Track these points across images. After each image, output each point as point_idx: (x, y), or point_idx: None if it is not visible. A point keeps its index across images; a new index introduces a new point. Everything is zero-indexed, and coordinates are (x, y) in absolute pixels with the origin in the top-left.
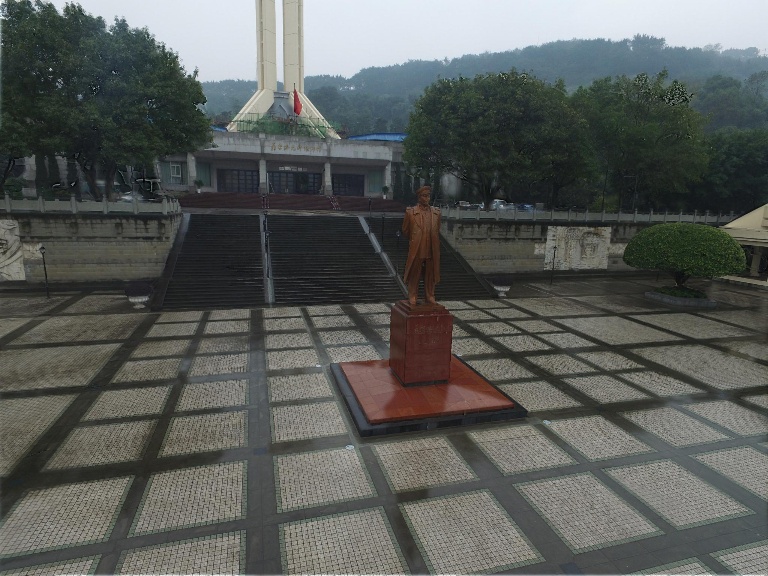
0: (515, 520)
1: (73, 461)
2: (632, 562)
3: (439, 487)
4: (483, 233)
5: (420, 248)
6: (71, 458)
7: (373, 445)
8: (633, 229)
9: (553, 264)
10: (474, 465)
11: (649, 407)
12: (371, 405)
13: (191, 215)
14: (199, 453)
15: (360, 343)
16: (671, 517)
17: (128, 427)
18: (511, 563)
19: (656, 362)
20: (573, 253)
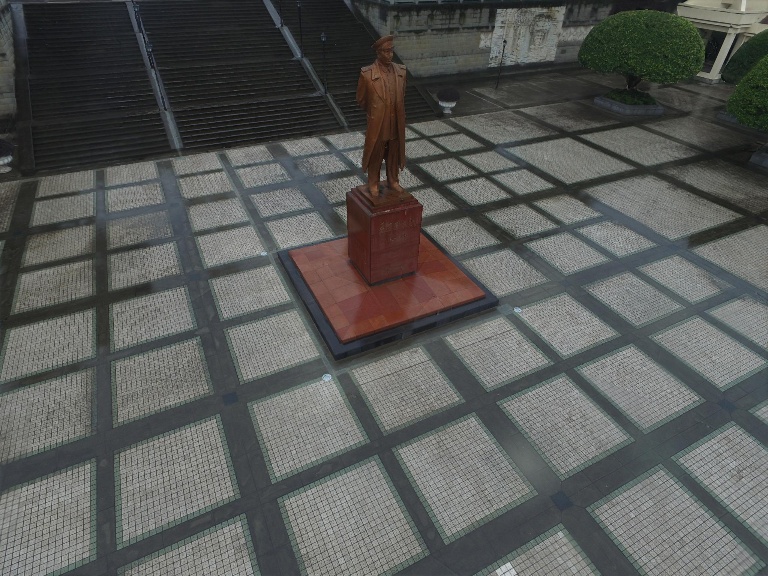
0: (505, 449)
1: (11, 450)
2: (610, 480)
3: (428, 419)
4: (422, 23)
5: (383, 127)
6: (7, 446)
7: (351, 370)
8: (588, 8)
9: (501, 63)
10: (457, 382)
11: (610, 274)
12: (339, 318)
13: (24, 6)
14: (161, 413)
15: (303, 210)
16: (638, 419)
17: (61, 385)
18: (508, 503)
19: (611, 206)
20: (521, 43)
